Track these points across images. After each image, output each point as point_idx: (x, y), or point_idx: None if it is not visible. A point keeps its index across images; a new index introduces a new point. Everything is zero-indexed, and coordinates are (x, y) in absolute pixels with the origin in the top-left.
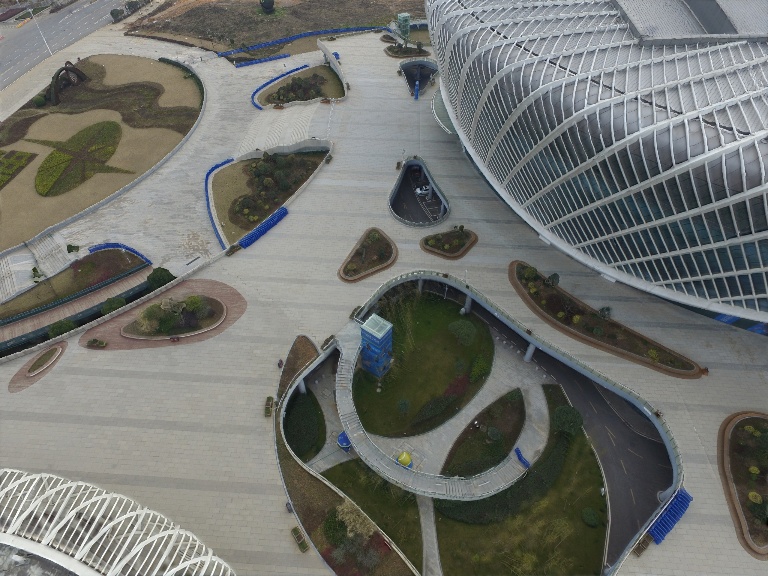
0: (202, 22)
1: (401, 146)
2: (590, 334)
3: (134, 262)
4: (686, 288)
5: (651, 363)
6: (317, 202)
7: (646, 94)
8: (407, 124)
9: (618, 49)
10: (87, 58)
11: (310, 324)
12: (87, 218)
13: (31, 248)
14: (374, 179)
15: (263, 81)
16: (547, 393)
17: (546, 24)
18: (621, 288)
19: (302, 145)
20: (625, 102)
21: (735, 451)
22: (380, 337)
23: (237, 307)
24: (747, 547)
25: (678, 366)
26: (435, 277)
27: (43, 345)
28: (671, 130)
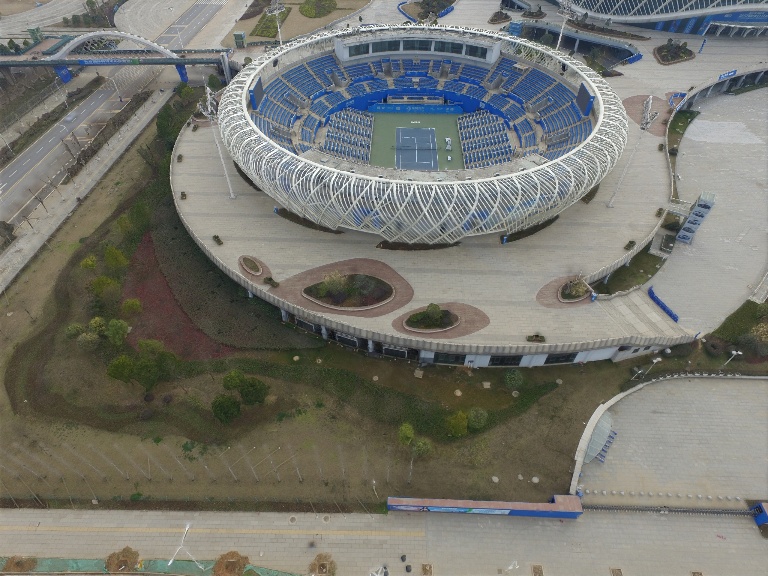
0: None
1: None
2: (602, 32)
3: None
4: (642, 11)
5: (628, 37)
6: (465, 7)
7: None
8: None
9: None
10: None
11: None
12: (348, 20)
13: (328, 29)
14: (489, 1)
15: None
16: (585, 57)
17: None
18: (615, 24)
19: None
20: None
21: (659, 49)
22: (520, 23)
23: None
24: (661, 64)
25: (639, 37)
26: (531, 23)
27: None
28: None
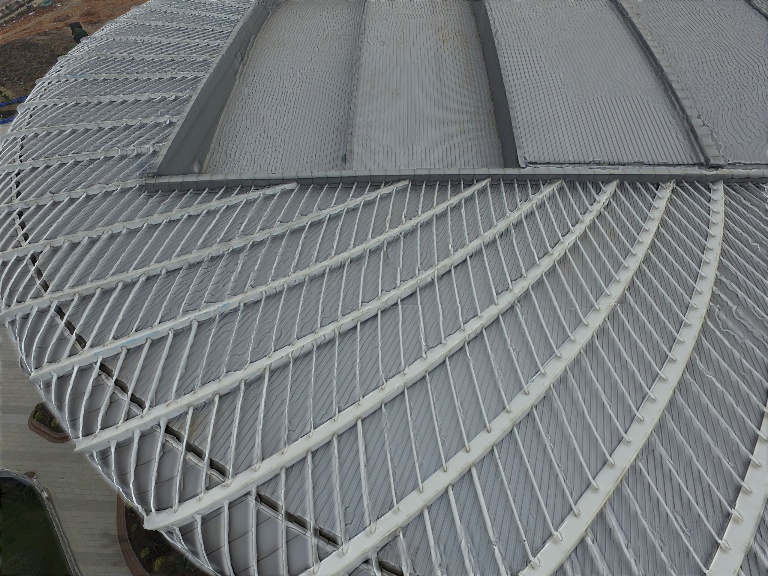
0: (4, 62)
1: None
2: None
3: None
4: None
5: None
6: None
7: (70, 299)
8: None
9: (110, 196)
10: None
11: None
12: None
13: None
14: None
15: None
16: None
17: (76, 138)
18: None
19: None
20: (31, 315)
21: None
22: None
23: None
24: None
25: None
26: (17, 476)
27: None
28: (52, 385)
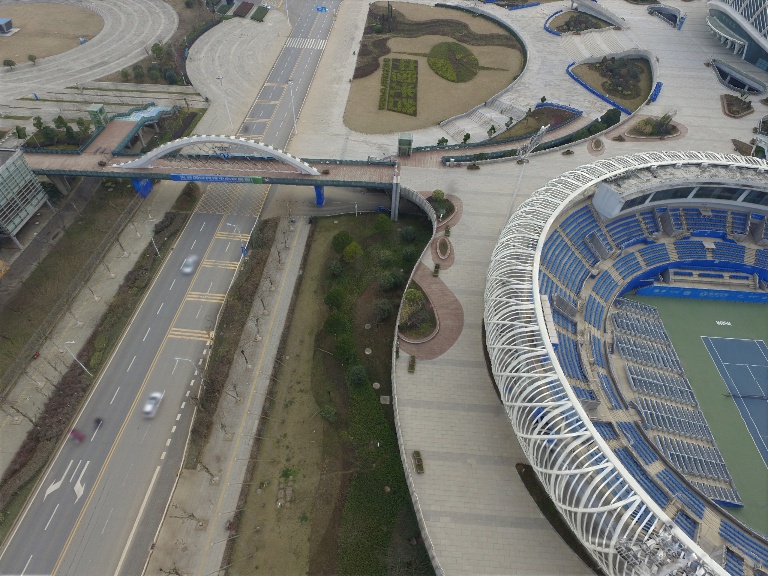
0: None
1: (697, 55)
2: None
3: (569, 114)
4: None
5: None
6: (673, 82)
7: None
8: (688, 43)
9: None
10: (374, 3)
11: (733, 135)
12: (511, 91)
13: (489, 107)
14: (697, 71)
15: (540, 19)
16: None
17: None
18: None
19: (627, 53)
20: None
21: None
22: None
23: (681, 127)
24: None
25: None
26: None
27: (590, 138)
28: None
